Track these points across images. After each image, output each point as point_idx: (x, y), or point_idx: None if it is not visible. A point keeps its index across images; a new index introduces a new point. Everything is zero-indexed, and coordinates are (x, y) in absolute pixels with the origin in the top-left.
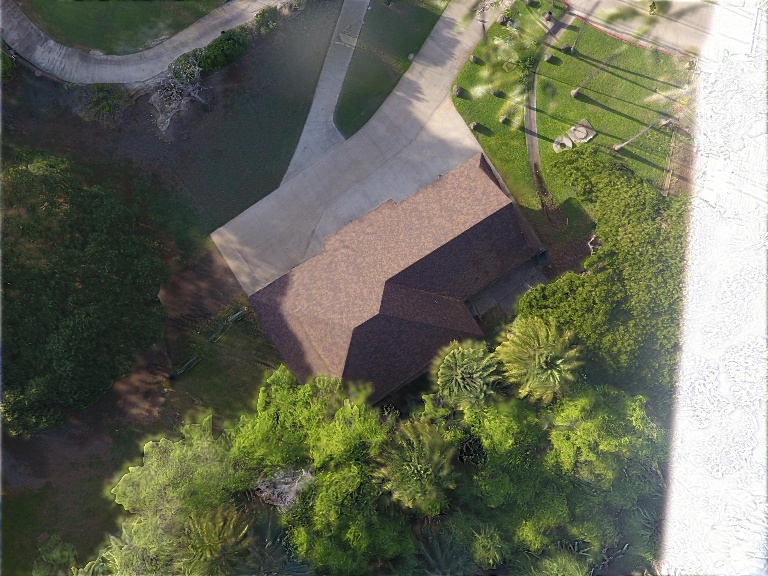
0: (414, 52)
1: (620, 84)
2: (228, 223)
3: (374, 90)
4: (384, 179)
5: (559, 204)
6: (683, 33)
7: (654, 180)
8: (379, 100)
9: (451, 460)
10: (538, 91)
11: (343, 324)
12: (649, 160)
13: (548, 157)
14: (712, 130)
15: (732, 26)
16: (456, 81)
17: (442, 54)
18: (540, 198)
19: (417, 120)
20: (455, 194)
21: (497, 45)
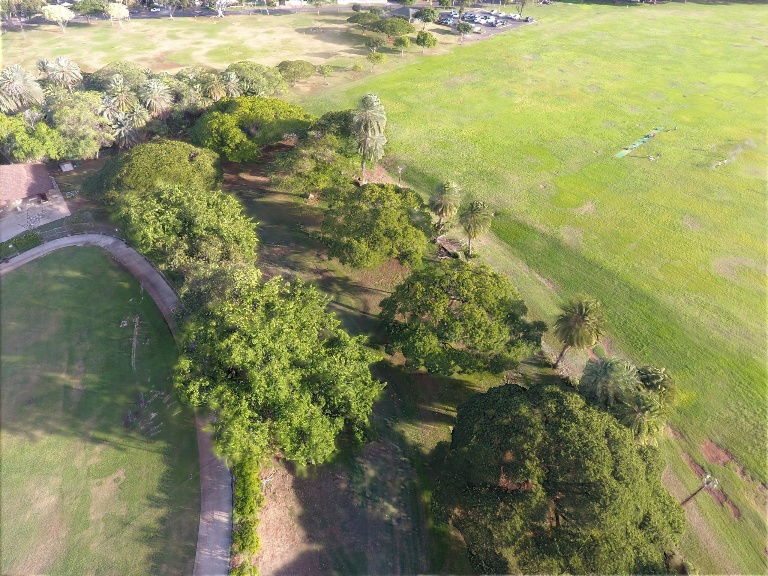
0: None
1: None
2: None
3: None
4: None
5: None
6: None
7: None
8: None
9: None
10: None
11: (3, 168)
12: None
13: None
14: None
15: None
16: None
17: None
18: None
19: None
20: None
21: None
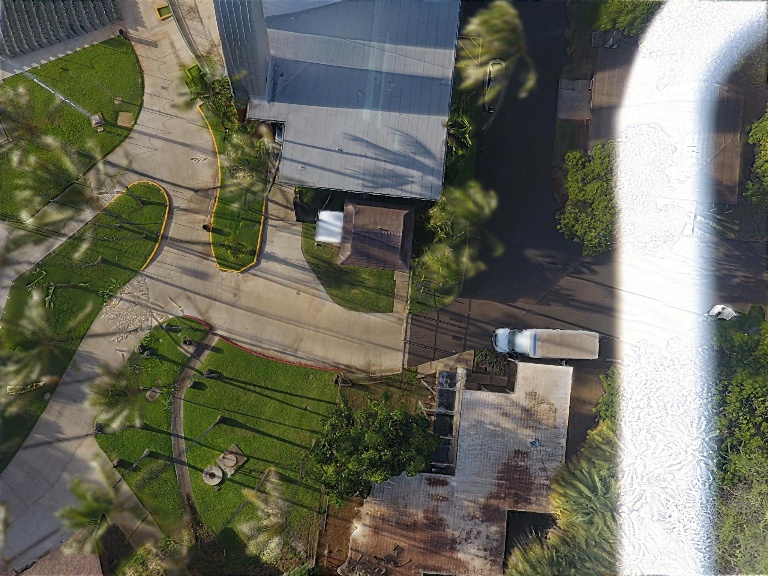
0: (50, 391)
1: (269, 404)
2: None
3: (8, 437)
4: (27, 527)
5: (215, 535)
6: (331, 345)
7: (311, 503)
8: (16, 445)
9: None
10: (185, 418)
11: None
12: (304, 482)
13: (199, 487)
14: (326, 487)
15: (382, 333)
16: (97, 416)
17: (81, 389)
18: (194, 531)
19: (58, 461)
20: (65, 573)
21: (138, 374)
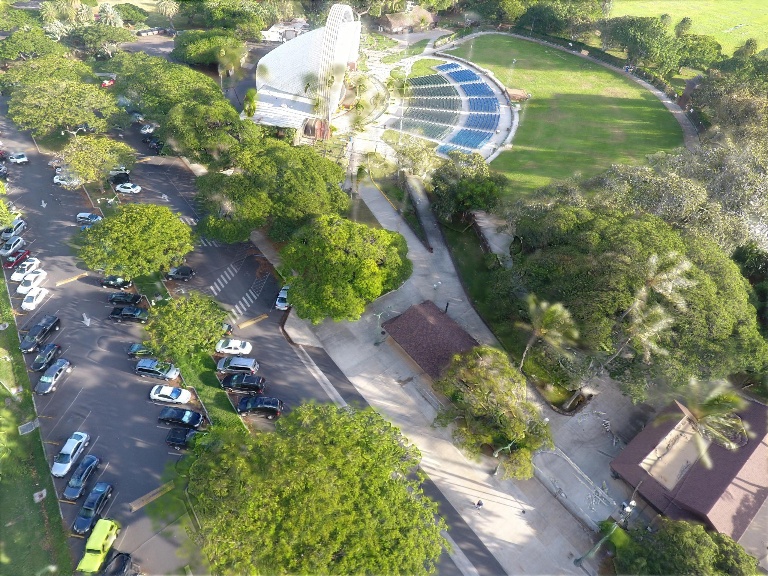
0: None
1: None
2: (452, 33)
3: None
4: None
5: None
6: None
7: None
8: None
9: (391, 7)
10: None
11: None
12: None
13: None
14: None
15: None
16: None
17: None
18: None
19: None
20: None
21: None
